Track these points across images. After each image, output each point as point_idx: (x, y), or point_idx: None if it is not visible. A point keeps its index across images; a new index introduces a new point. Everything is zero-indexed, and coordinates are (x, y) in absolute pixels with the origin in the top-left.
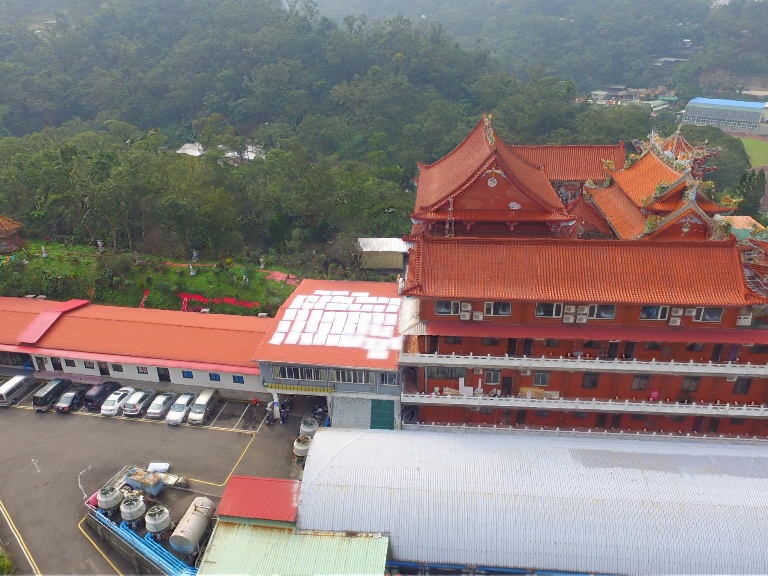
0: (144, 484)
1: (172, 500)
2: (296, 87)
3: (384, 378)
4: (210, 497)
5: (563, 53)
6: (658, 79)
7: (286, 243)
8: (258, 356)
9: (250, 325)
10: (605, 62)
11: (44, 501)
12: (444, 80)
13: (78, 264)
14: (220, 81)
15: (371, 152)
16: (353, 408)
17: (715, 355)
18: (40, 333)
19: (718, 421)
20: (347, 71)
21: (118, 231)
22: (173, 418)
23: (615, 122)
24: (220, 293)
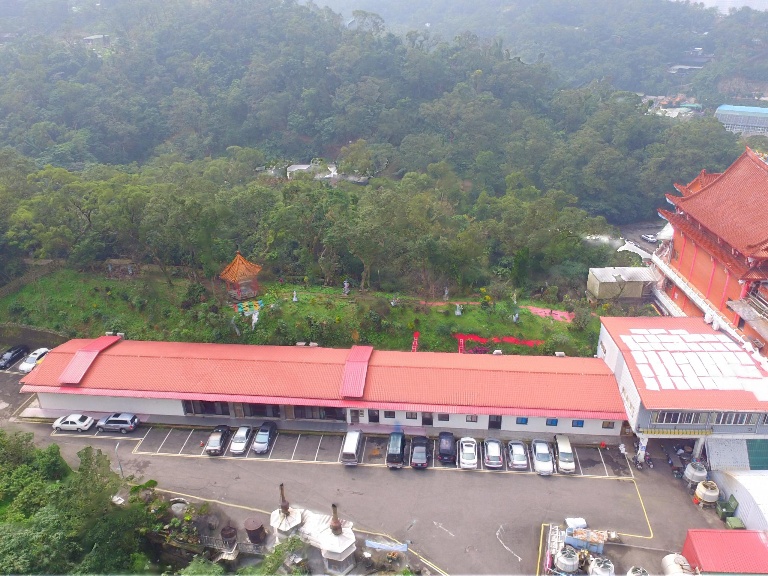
0: (592, 543)
1: (616, 557)
2: None
3: (766, 418)
4: (652, 551)
5: (583, 62)
6: None
7: (482, 272)
8: (650, 404)
9: (566, 367)
10: (624, 70)
11: (485, 567)
12: (517, 95)
13: (334, 307)
14: (304, 100)
15: (510, 174)
16: (729, 449)
17: None
18: (361, 386)
19: None
20: (421, 87)
21: (338, 269)
22: (545, 469)
23: (698, 135)
24: (496, 332)
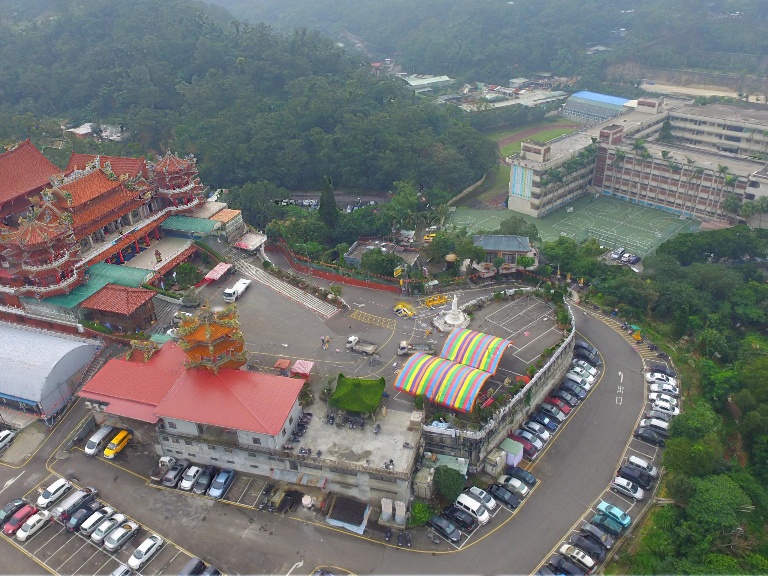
0: None
1: None
2: (154, 84)
3: None
4: None
5: (497, 40)
6: (583, 68)
7: None
8: None
9: None
10: (535, 50)
11: None
12: (284, 78)
13: None
14: (111, 77)
15: None
16: None
17: (2, 281)
18: None
19: (23, 317)
20: None
21: None
22: None
23: None
24: None
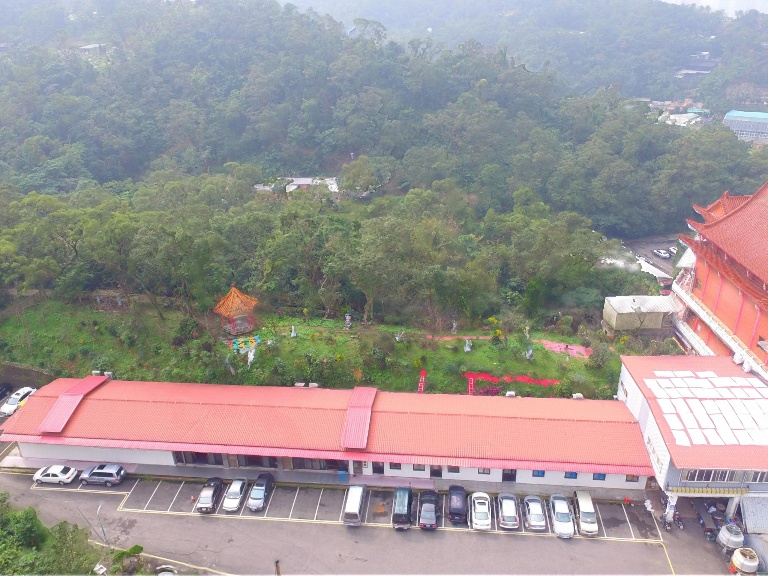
0: None
1: None
2: (388, 117)
3: None
4: None
5: (588, 67)
6: None
7: (491, 298)
8: (681, 462)
9: (585, 412)
10: (630, 76)
11: None
12: (523, 104)
13: (335, 343)
14: (304, 112)
15: (518, 190)
16: (766, 509)
17: None
18: (364, 435)
19: None
20: (425, 97)
21: (340, 298)
22: (565, 531)
23: (710, 145)
24: (508, 371)
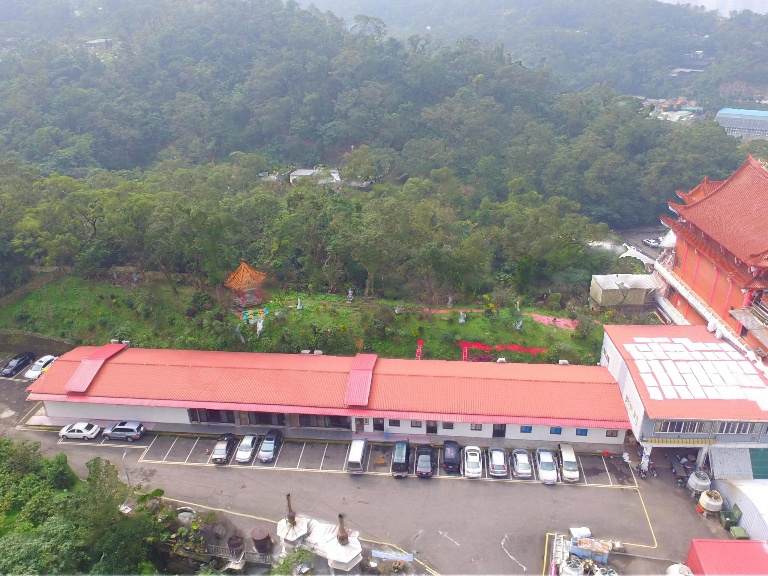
0: (596, 553)
1: (621, 566)
2: (388, 110)
3: None
4: (656, 561)
5: (584, 65)
6: None
7: None
8: (654, 413)
9: (569, 375)
10: (625, 74)
11: None
12: (519, 99)
13: (338, 315)
14: (306, 105)
15: (512, 179)
16: (732, 458)
17: None
18: (366, 394)
19: None
20: (423, 92)
21: (342, 276)
22: (549, 478)
23: (699, 139)
24: (500, 340)
